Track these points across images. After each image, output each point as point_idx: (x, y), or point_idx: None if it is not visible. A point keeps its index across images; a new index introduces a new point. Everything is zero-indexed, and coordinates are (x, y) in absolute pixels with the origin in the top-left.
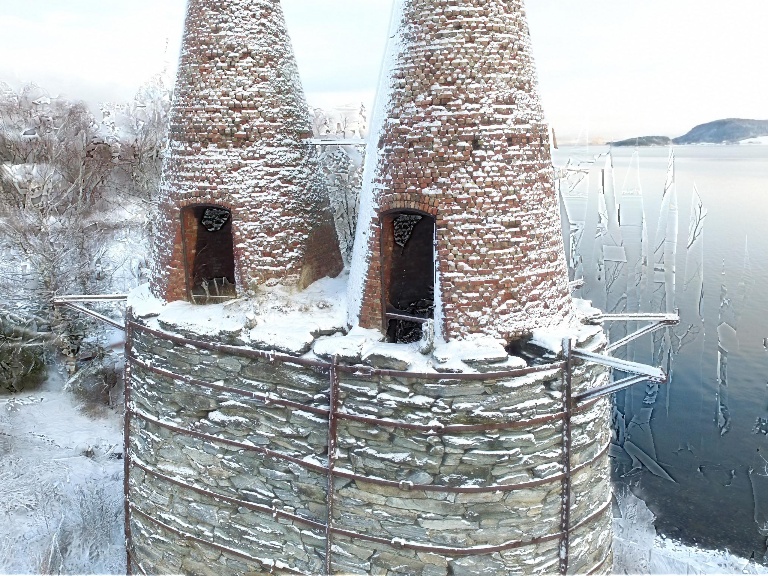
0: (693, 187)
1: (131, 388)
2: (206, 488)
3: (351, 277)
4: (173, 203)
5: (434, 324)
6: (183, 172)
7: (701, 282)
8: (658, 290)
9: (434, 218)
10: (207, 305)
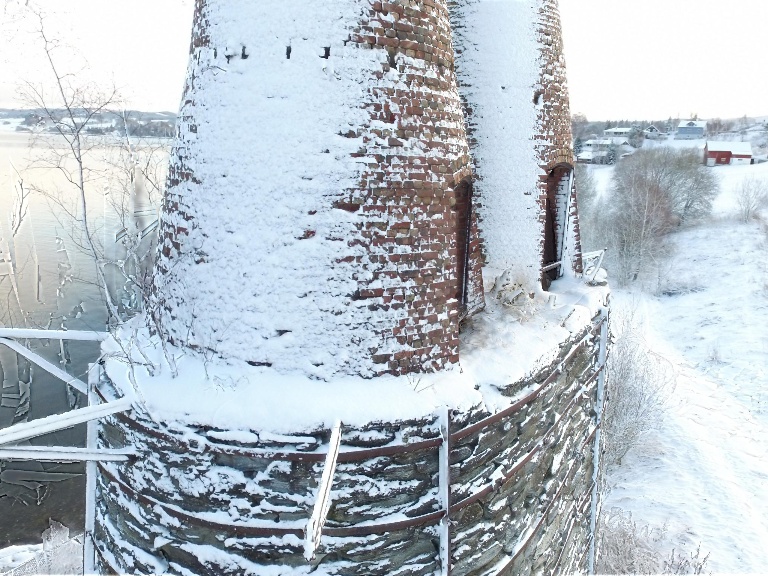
0: (9, 162)
1: (451, 570)
2: (551, 573)
3: (510, 246)
4: (444, 180)
5: (565, 264)
6: (446, 121)
7: (36, 265)
8: (0, 285)
9: (572, 170)
10: (484, 338)
